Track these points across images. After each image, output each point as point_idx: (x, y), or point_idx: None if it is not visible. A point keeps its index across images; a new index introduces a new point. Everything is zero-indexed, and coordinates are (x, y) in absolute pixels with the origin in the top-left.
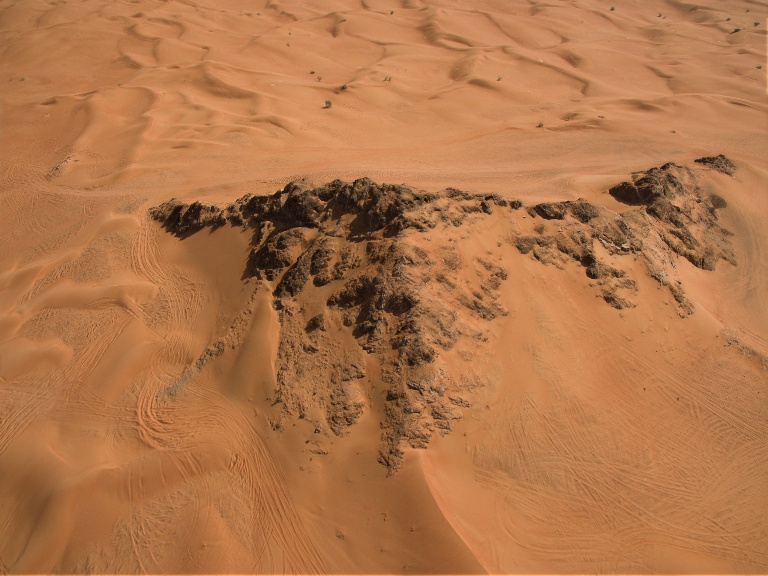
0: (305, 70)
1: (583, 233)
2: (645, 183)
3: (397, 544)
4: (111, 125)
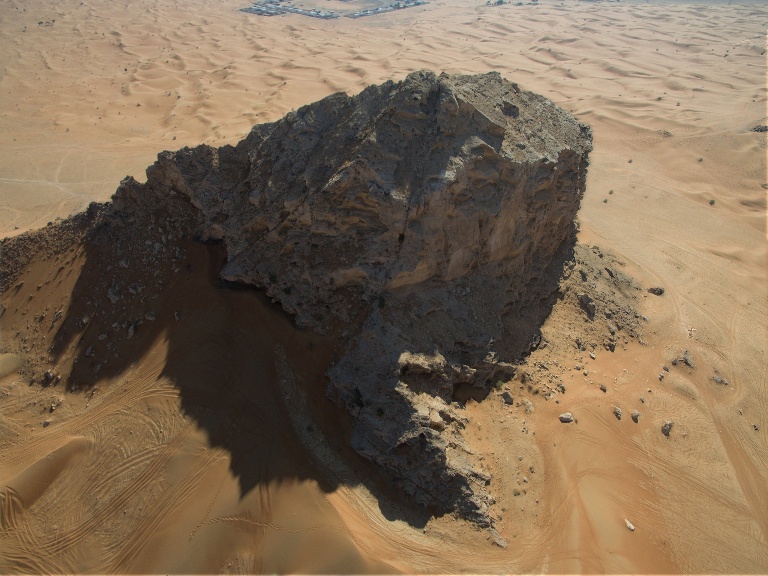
0: None
1: None
2: None
3: None
4: (632, 121)
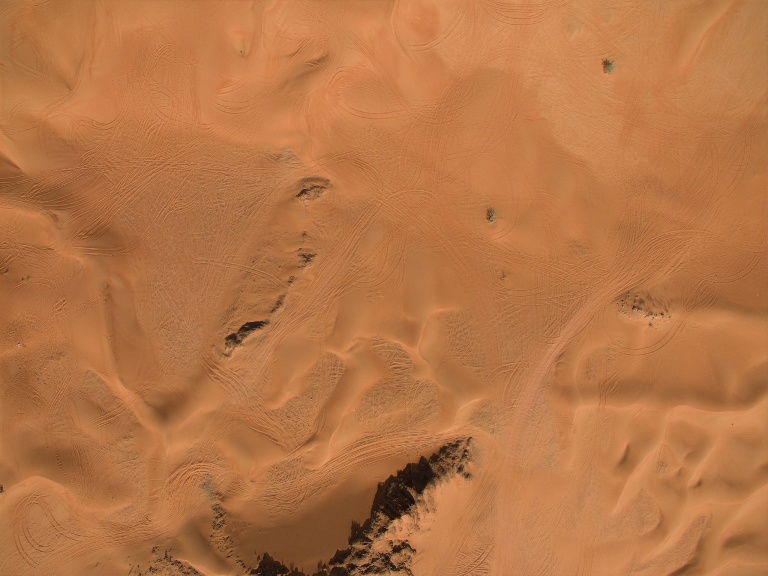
0: None
1: None
2: None
3: None
4: (763, 345)
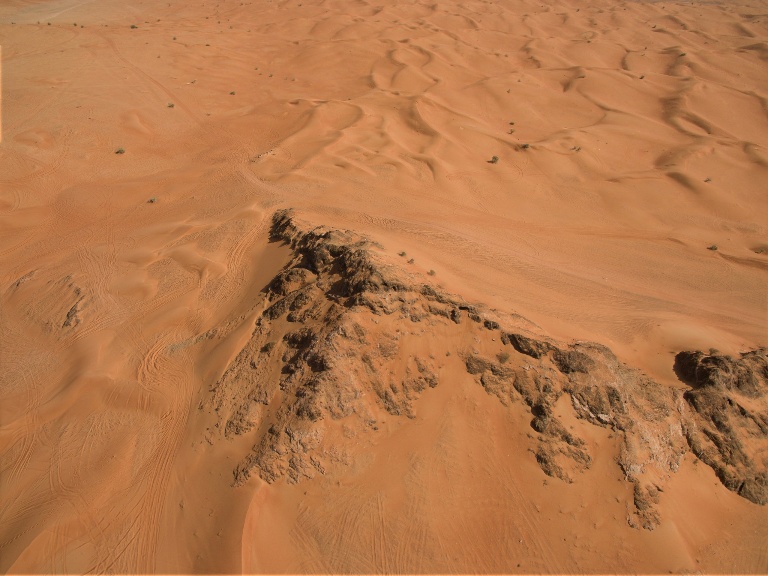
0: (507, 119)
1: (552, 382)
2: (712, 363)
3: (205, 537)
4: (317, 132)
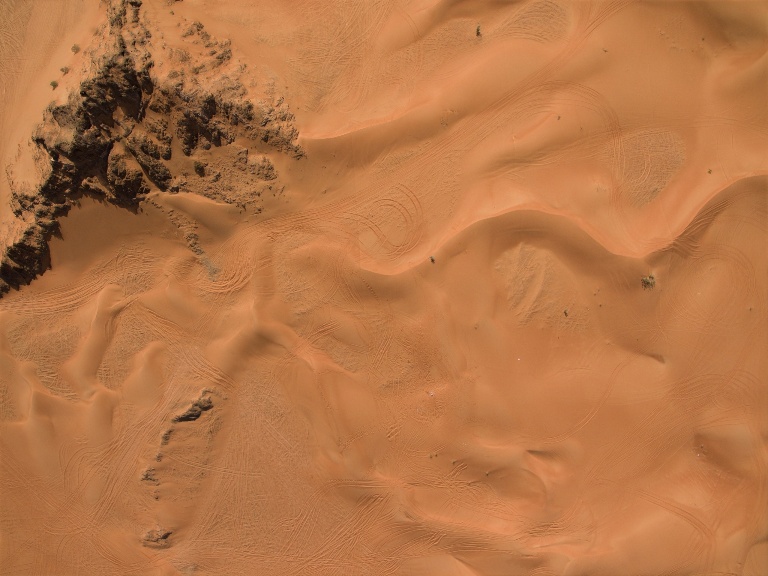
0: None
1: None
2: None
3: (338, 166)
4: None
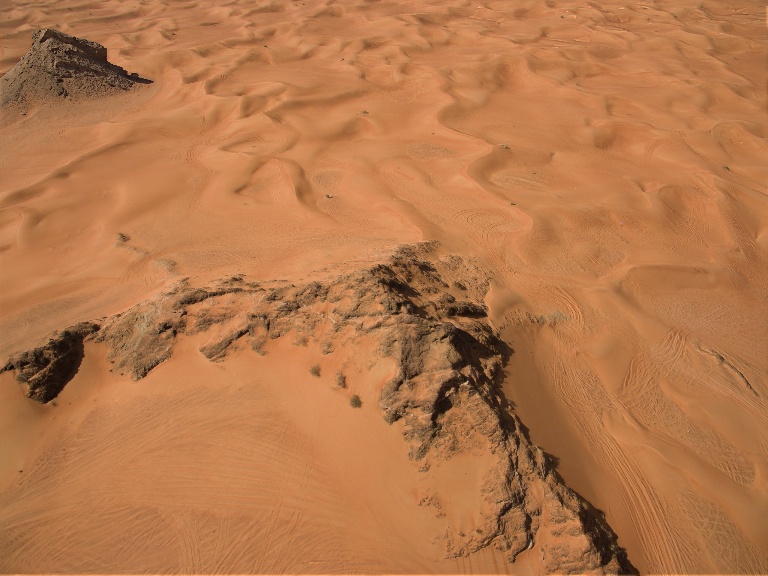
0: None
1: None
2: (45, 355)
3: None
4: None
